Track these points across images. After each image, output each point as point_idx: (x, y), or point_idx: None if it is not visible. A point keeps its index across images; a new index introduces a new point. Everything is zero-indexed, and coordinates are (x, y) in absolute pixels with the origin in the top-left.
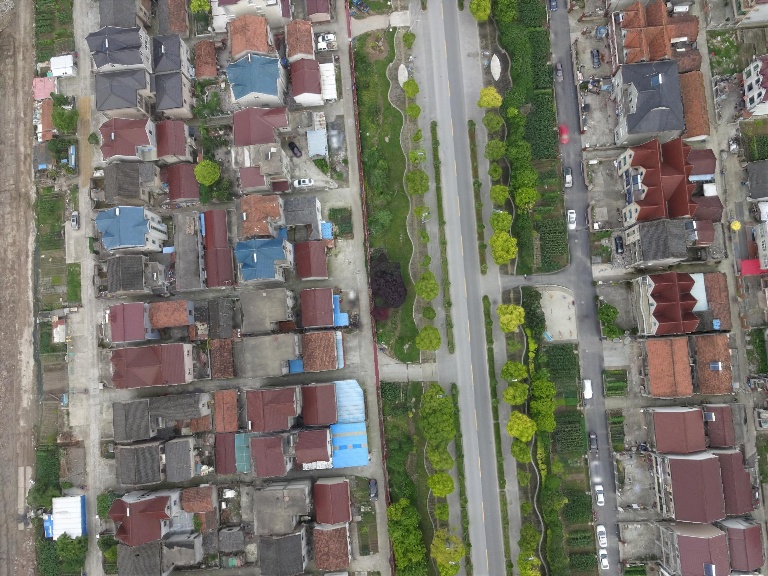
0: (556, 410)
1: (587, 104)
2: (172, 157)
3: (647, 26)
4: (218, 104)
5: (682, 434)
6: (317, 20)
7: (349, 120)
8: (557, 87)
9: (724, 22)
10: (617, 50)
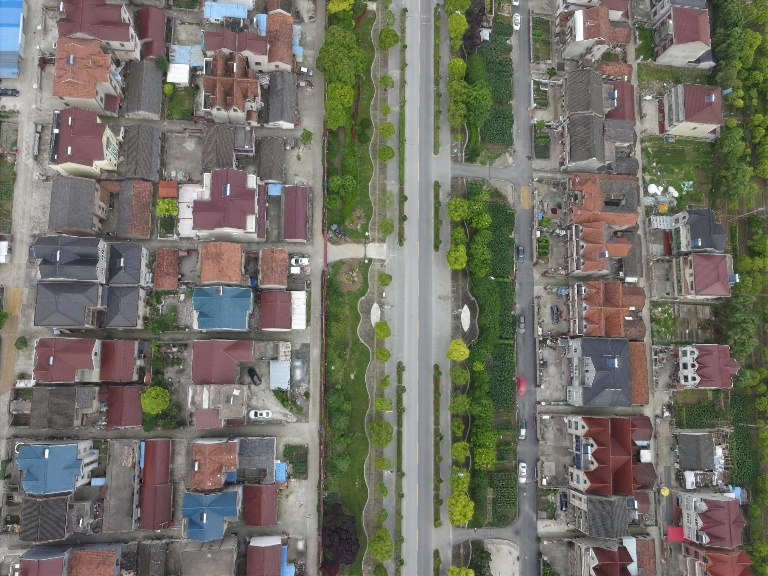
0: None
1: (545, 361)
2: None
3: (606, 303)
4: (175, 320)
5: None
6: (292, 241)
7: (315, 350)
8: (518, 337)
9: (665, 295)
10: (578, 320)
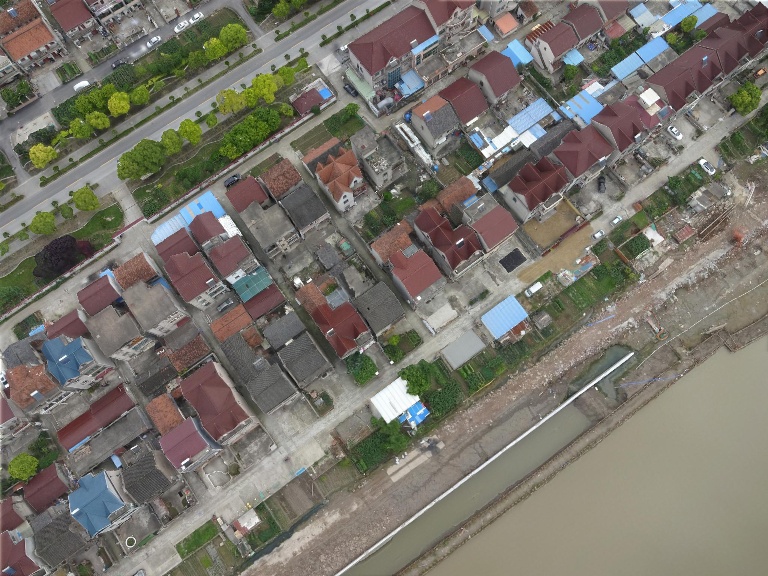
0: None
1: None
2: (18, 508)
3: None
4: None
5: (67, 6)
6: None
7: None
8: None
9: None
10: None
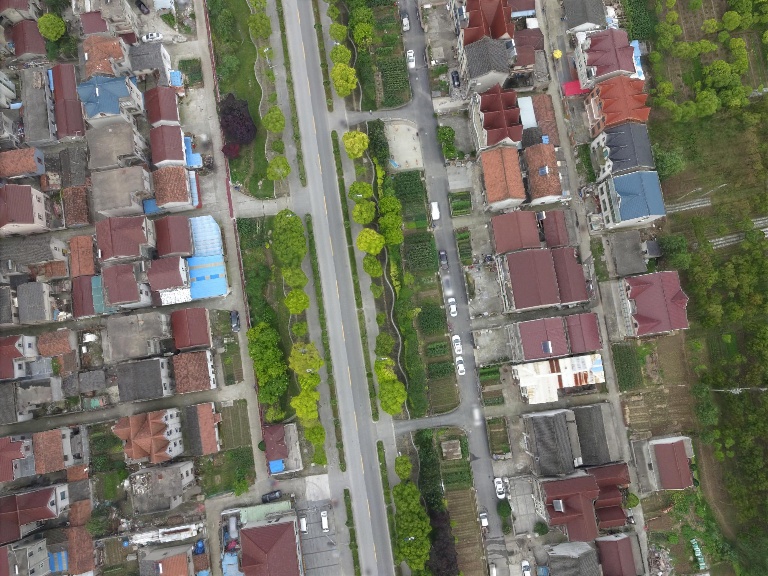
0: (408, 233)
1: None
2: (14, 13)
3: None
4: None
5: (516, 231)
6: None
7: None
8: None
9: None
10: None
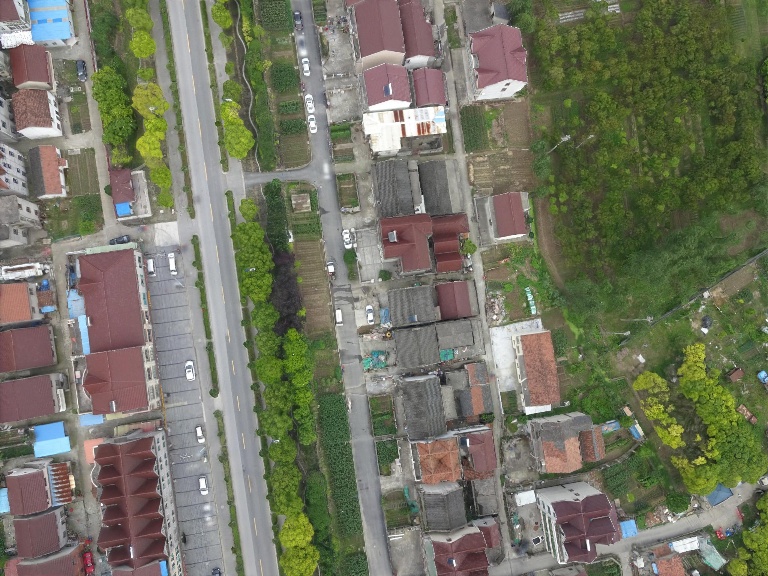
0: None
1: None
2: None
3: None
4: None
5: None
6: None
7: None
8: None
9: None
10: None
